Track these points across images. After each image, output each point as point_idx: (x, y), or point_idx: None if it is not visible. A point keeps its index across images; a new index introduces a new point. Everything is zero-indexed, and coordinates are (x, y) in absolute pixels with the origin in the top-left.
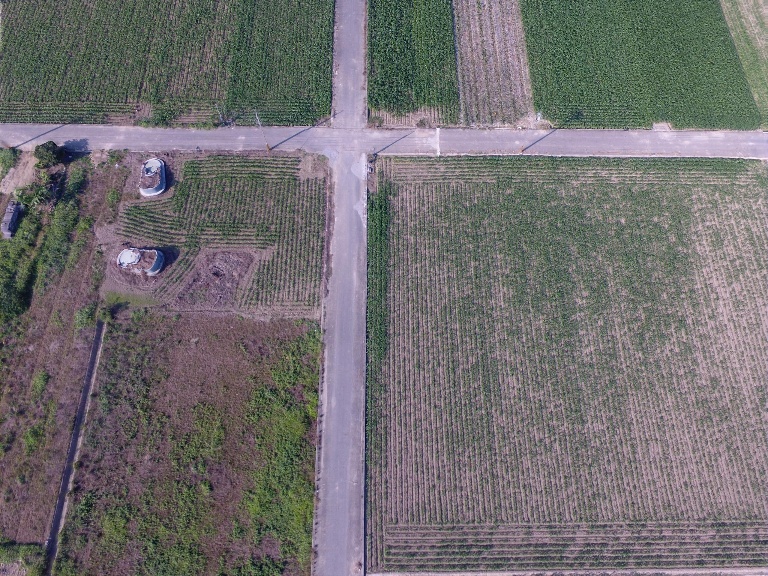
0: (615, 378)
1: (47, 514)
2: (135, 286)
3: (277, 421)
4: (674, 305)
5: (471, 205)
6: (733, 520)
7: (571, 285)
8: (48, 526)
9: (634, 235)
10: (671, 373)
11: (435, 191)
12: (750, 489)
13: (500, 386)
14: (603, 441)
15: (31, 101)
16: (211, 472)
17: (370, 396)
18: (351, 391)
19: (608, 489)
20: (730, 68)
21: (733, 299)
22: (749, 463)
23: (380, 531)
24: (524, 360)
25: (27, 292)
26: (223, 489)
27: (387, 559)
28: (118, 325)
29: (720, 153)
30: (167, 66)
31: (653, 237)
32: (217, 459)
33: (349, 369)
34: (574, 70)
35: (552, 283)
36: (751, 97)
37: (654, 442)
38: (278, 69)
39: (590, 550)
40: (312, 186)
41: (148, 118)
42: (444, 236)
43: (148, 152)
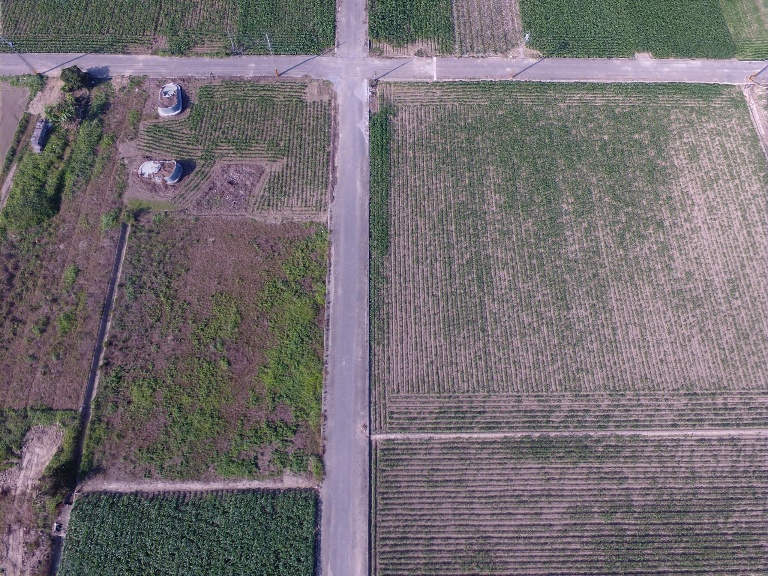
0: (598, 272)
1: (81, 385)
2: (156, 194)
3: (288, 308)
4: (653, 210)
5: (465, 124)
6: (704, 391)
7: (558, 192)
8: (82, 395)
9: (616, 149)
10: (649, 268)
11: (432, 112)
12: (720, 365)
13: (492, 278)
14: (586, 325)
15: (55, 33)
16: (229, 350)
17: (373, 287)
18: (356, 282)
19: (591, 365)
20: (707, 4)
21: (707, 205)
22: (719, 343)
23: (383, 399)
24: (514, 256)
25: (57, 198)
26: (240, 365)
27: (390, 423)
28: (141, 226)
29: (697, 79)
30: (181, 3)
31: (634, 152)
32: (234, 339)
33: (354, 263)
34: (561, 6)
35: (540, 191)
36: (727, 30)
37: (633, 326)
38: (285, 5)
39: (574, 415)
40: (318, 108)
41: (164, 49)
42: (440, 150)
43: (165, 78)
